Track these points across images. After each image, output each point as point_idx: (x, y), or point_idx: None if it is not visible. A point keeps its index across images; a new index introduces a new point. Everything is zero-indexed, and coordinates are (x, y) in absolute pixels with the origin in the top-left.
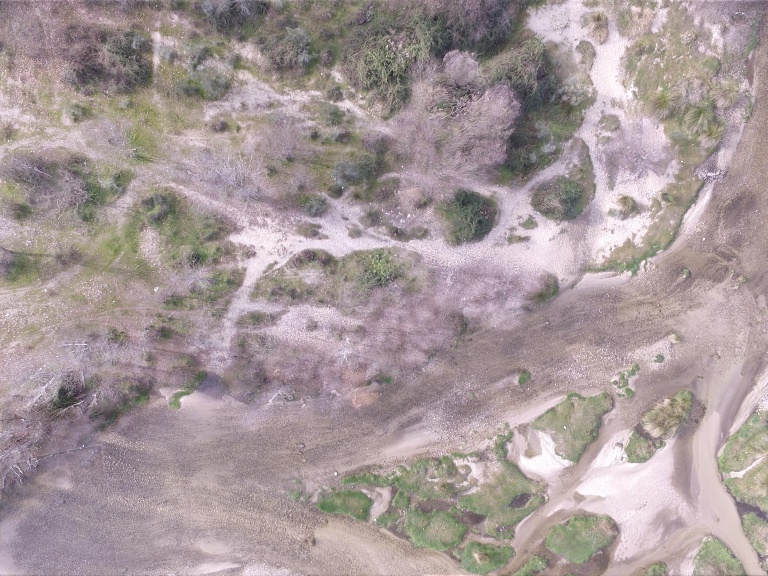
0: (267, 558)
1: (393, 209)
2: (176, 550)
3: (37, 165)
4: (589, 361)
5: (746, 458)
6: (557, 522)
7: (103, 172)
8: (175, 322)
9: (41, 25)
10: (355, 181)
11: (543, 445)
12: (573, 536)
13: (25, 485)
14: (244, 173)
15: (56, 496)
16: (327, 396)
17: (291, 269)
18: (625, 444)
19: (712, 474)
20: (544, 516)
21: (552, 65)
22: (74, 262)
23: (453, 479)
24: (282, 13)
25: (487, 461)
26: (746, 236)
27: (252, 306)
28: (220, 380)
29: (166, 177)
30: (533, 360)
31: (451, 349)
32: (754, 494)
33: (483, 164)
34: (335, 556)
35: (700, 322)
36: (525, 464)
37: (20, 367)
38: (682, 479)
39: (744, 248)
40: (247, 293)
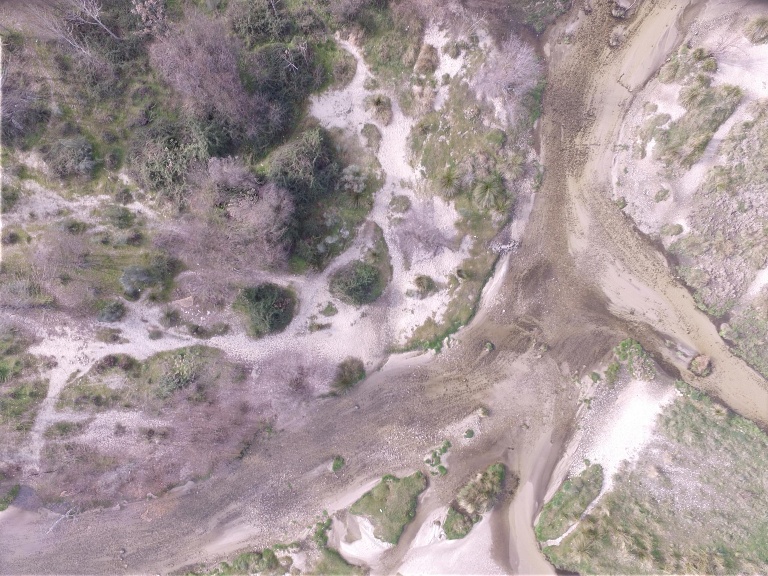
0: None
1: (192, 307)
2: None
3: None
4: (401, 442)
5: (561, 525)
6: None
7: None
8: None
9: None
10: (151, 283)
11: (362, 530)
12: None
13: None
14: (39, 284)
15: None
16: (143, 499)
17: (95, 376)
18: (442, 521)
19: (530, 543)
20: None
21: (337, 151)
22: None
23: (274, 572)
24: (64, 119)
25: (308, 550)
26: (545, 305)
27: (58, 417)
28: (34, 493)
29: None
30: (346, 445)
31: (264, 441)
32: (571, 560)
33: None
34: None
35: (507, 394)
36: (345, 550)
37: None
38: (501, 551)
39: (544, 317)
40: (52, 404)
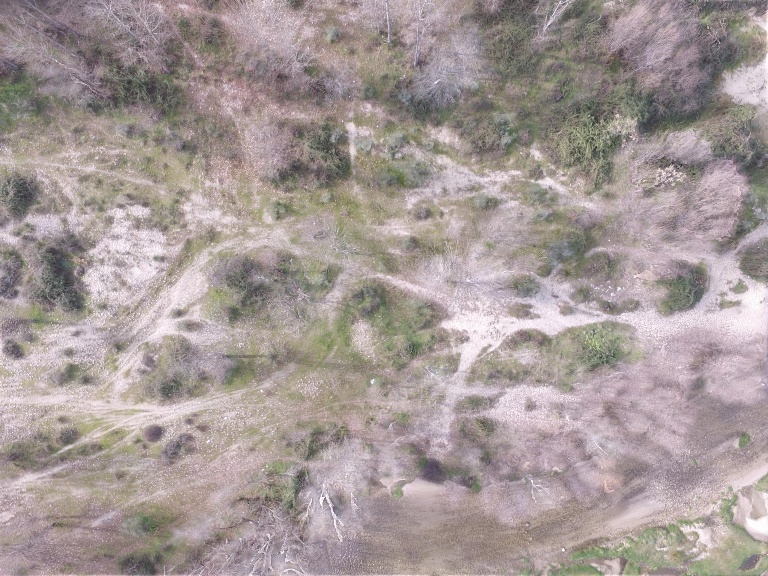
0: None
1: (603, 283)
2: None
3: (247, 267)
4: None
5: None
6: None
7: (310, 268)
8: (394, 413)
9: (235, 125)
10: (563, 258)
11: (767, 506)
12: None
13: None
14: (451, 258)
15: None
16: (548, 473)
17: (505, 351)
18: None
19: None
20: None
21: (753, 128)
22: (288, 361)
23: (682, 547)
24: (476, 95)
25: (713, 526)
26: None
27: (469, 391)
28: (440, 466)
29: (373, 268)
30: (751, 422)
31: (668, 417)
32: None
33: None
34: None
35: None
36: (752, 526)
37: (242, 469)
38: None
39: None
40: (463, 378)
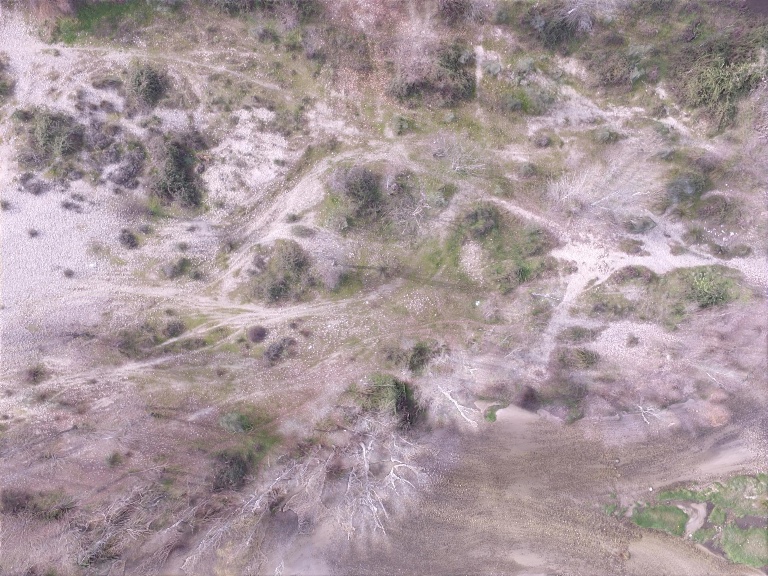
0: (581, 571)
1: (716, 227)
2: (490, 561)
3: (366, 178)
4: None
5: None
6: None
7: (426, 186)
8: (496, 336)
9: (365, 38)
10: (679, 198)
11: None
12: None
13: (338, 494)
14: (567, 189)
15: None
16: None
17: (612, 285)
18: None
19: None
20: None
21: None
22: (396, 275)
23: None
24: (607, 29)
25: None
26: None
27: (572, 321)
28: (536, 394)
29: (488, 192)
30: None
31: None
32: None
33: None
34: (650, 570)
35: None
36: None
37: (341, 378)
38: None
39: None
40: (567, 308)
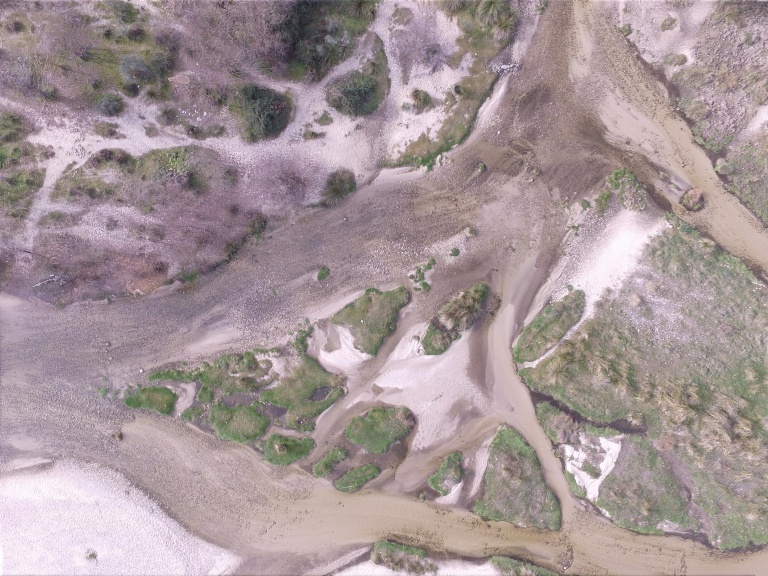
0: (76, 453)
1: (189, 107)
2: None
3: None
4: (387, 256)
5: (539, 348)
6: (356, 414)
7: None
8: None
9: None
10: (150, 79)
11: (342, 339)
12: (371, 427)
13: None
14: (40, 73)
15: None
16: (131, 295)
17: (90, 169)
18: (422, 337)
19: (507, 365)
20: (343, 408)
21: None
22: None
23: (254, 373)
24: None
25: (288, 356)
26: (540, 129)
27: (53, 206)
28: (26, 281)
29: None
30: (332, 256)
31: (252, 247)
32: (546, 383)
33: (257, 51)
34: (142, 450)
35: (495, 215)
36: (324, 358)
37: None
38: (477, 370)
39: (539, 141)
40: (48, 194)
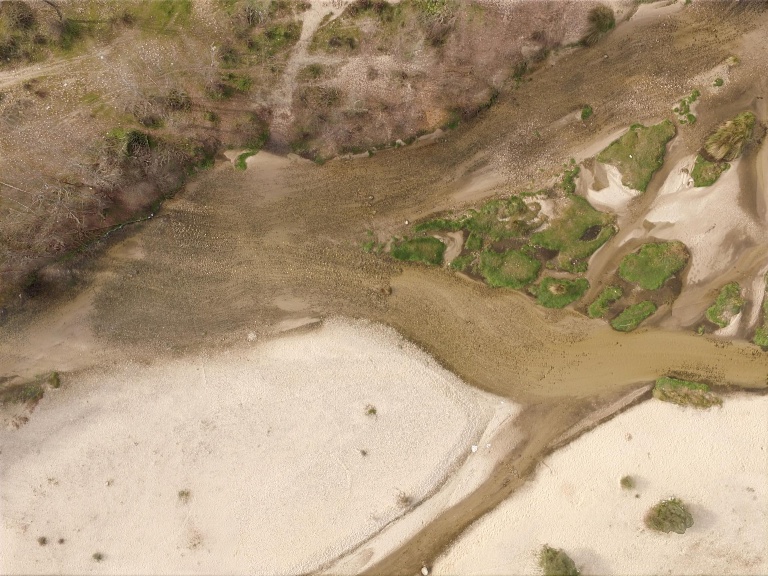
0: (345, 311)
1: None
2: (253, 310)
3: None
4: (649, 91)
5: None
6: (629, 251)
7: None
8: (235, 80)
9: None
10: None
11: (610, 177)
12: (645, 263)
13: (96, 259)
14: None
15: (128, 268)
16: (392, 146)
17: (347, 19)
18: (690, 169)
19: None
20: (615, 246)
21: None
22: (129, 27)
23: (524, 216)
24: None
25: (555, 198)
26: None
27: (311, 59)
28: (284, 139)
29: None
30: (594, 95)
31: (512, 91)
32: None
33: None
34: (412, 303)
35: (756, 44)
36: (593, 197)
37: (83, 137)
38: (748, 199)
39: None
40: (305, 47)
